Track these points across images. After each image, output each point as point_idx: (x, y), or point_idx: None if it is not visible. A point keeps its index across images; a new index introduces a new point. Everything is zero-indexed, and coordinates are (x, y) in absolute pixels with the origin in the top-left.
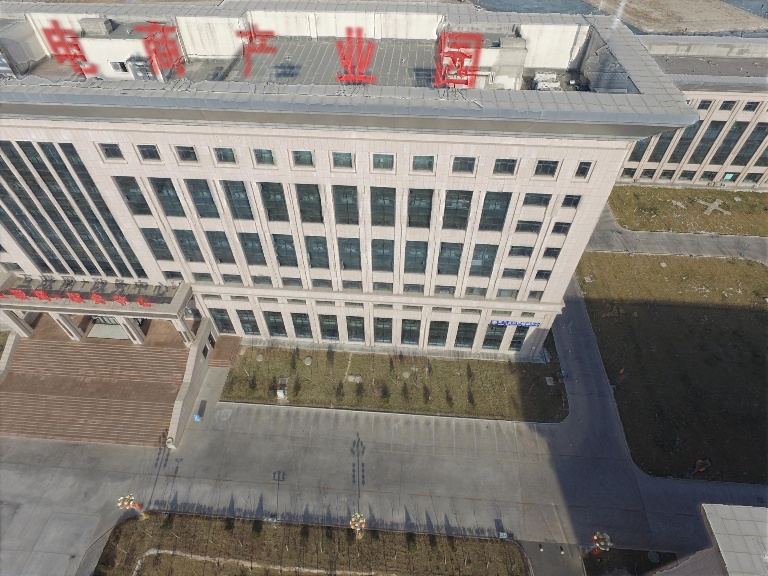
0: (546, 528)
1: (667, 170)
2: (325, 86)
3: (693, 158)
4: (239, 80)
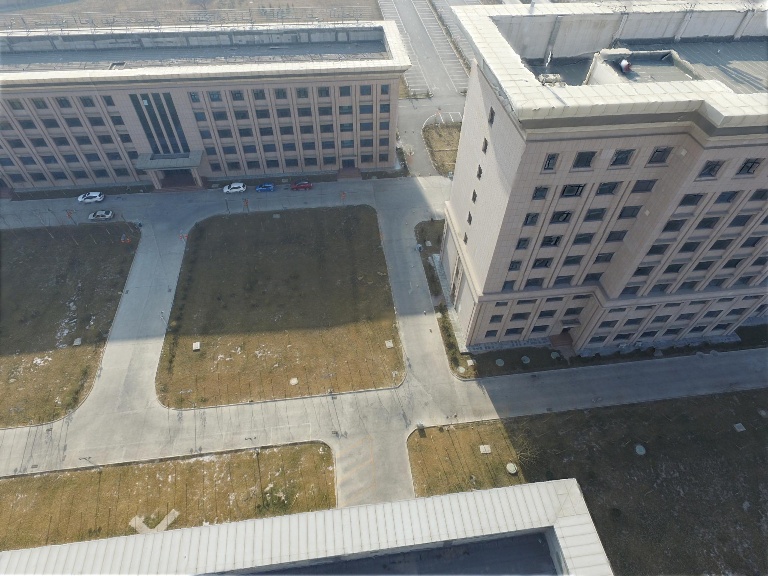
0: (428, 180)
1: None
2: (709, 7)
3: None
4: None
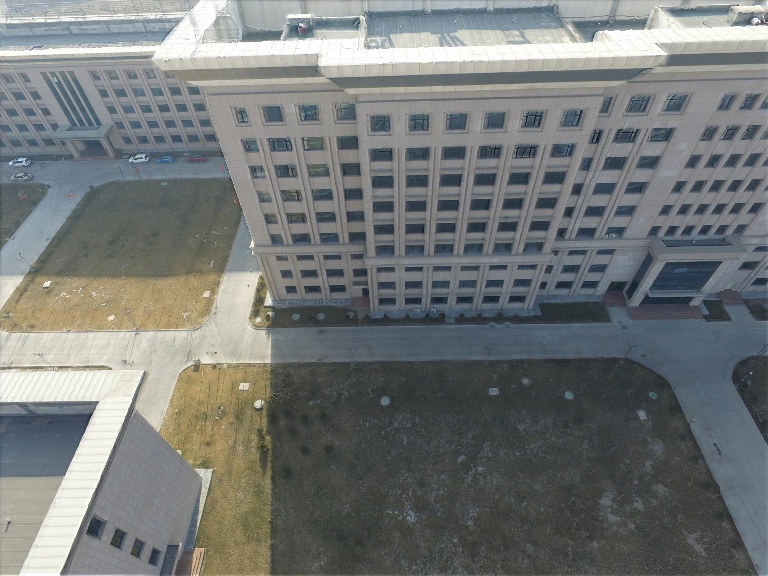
0: None
1: None
2: None
3: None
4: (554, 37)
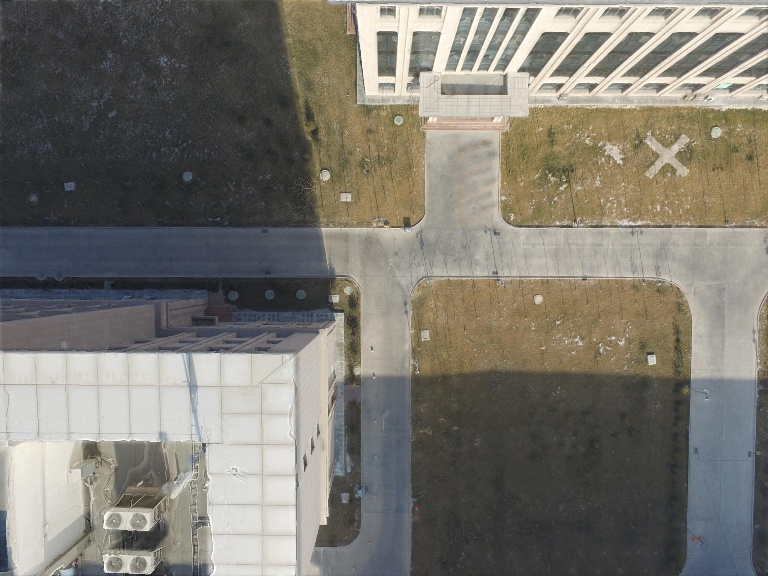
0: None
1: (618, 82)
2: None
3: (667, 71)
4: None
